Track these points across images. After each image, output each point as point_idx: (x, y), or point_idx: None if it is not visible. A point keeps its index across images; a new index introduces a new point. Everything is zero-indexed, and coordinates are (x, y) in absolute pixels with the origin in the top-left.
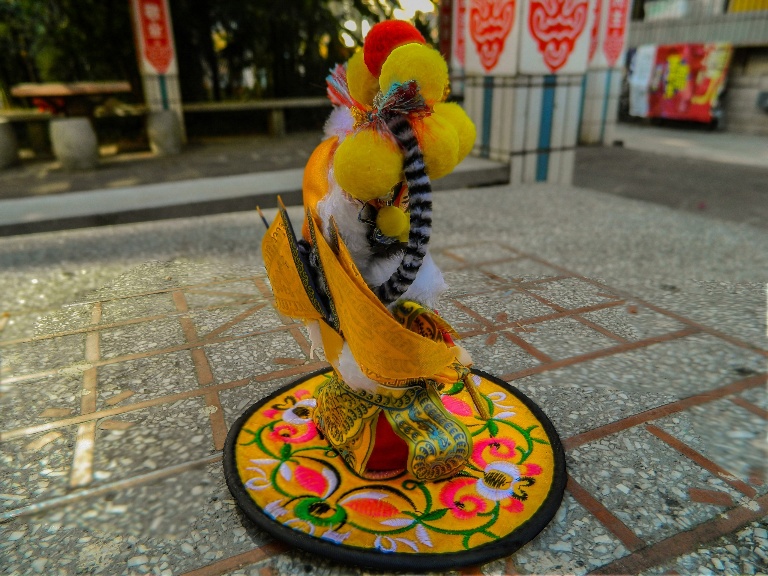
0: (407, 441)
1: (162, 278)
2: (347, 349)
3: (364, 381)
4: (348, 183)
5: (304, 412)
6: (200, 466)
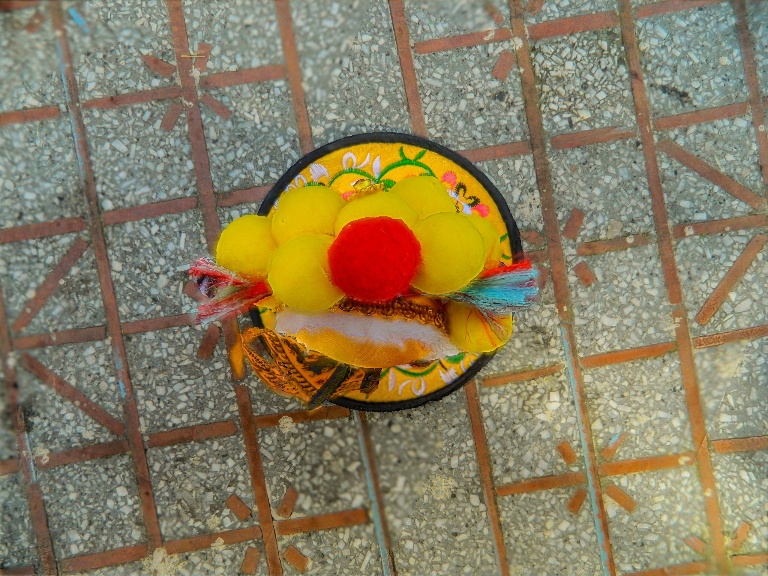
0: None
1: None
2: None
3: None
4: None
5: None
6: (368, 428)
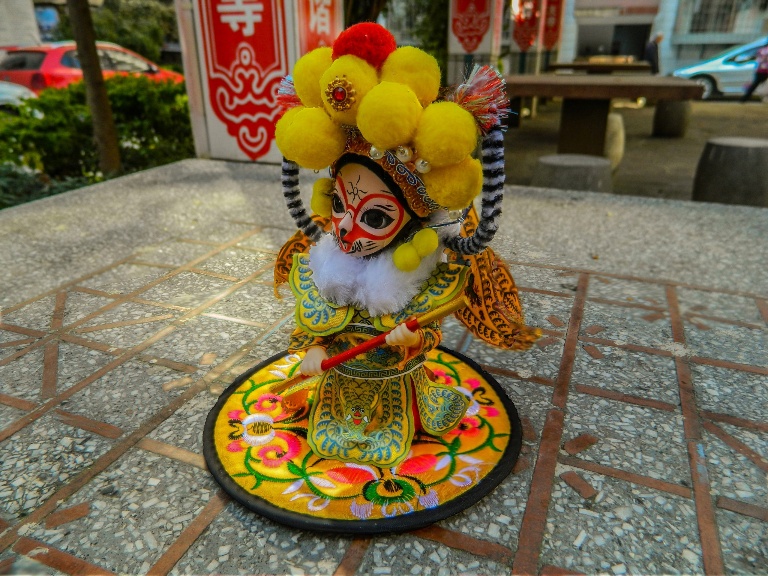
0: None
1: None
2: None
3: None
4: None
5: None
6: None
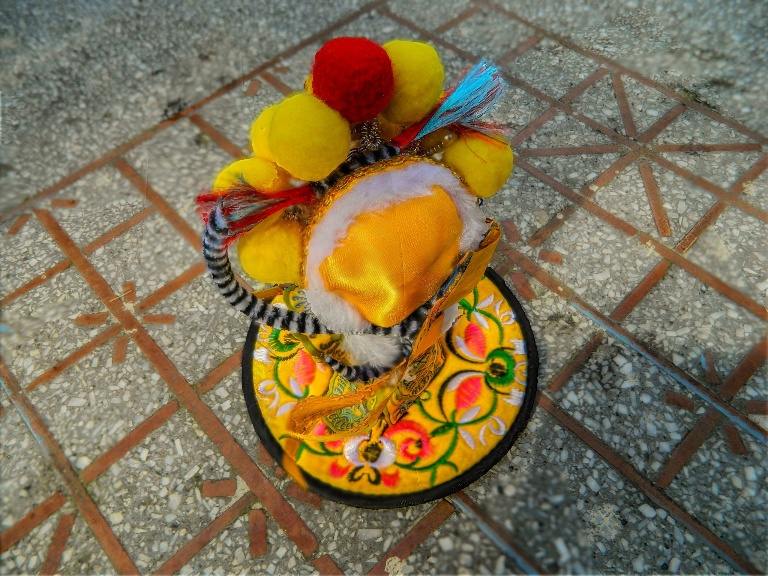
0: None
1: None
2: (451, 309)
3: None
4: None
5: (373, 449)
6: (482, 510)
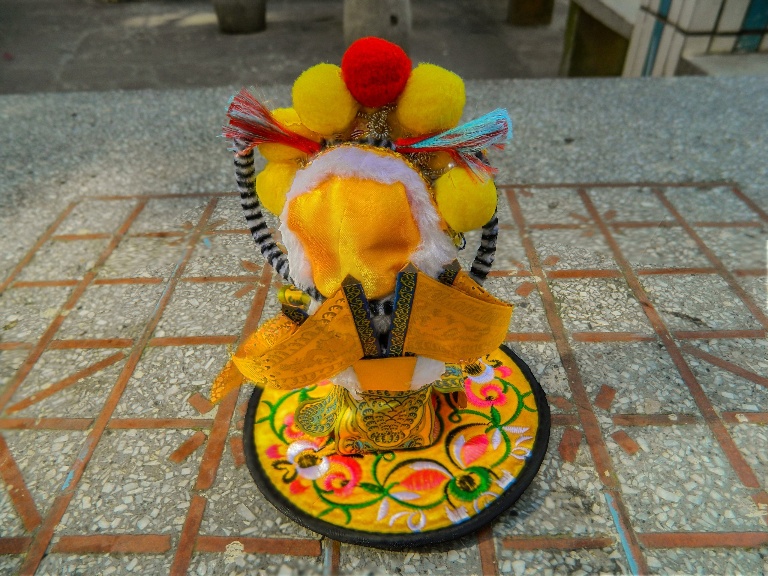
0: (459, 390)
1: None
2: (428, 361)
3: None
4: None
5: (311, 459)
6: None
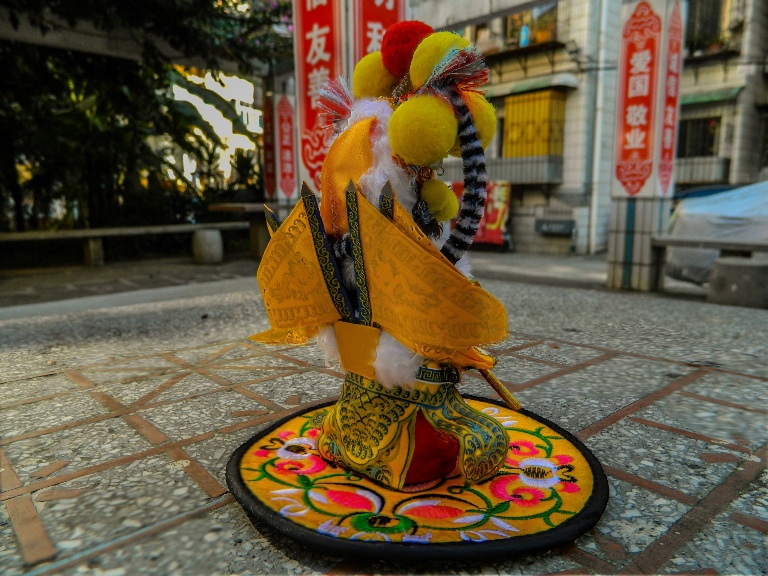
0: (455, 435)
1: (43, 363)
2: (388, 337)
3: (405, 373)
4: (412, 142)
5: (300, 448)
6: (201, 514)
